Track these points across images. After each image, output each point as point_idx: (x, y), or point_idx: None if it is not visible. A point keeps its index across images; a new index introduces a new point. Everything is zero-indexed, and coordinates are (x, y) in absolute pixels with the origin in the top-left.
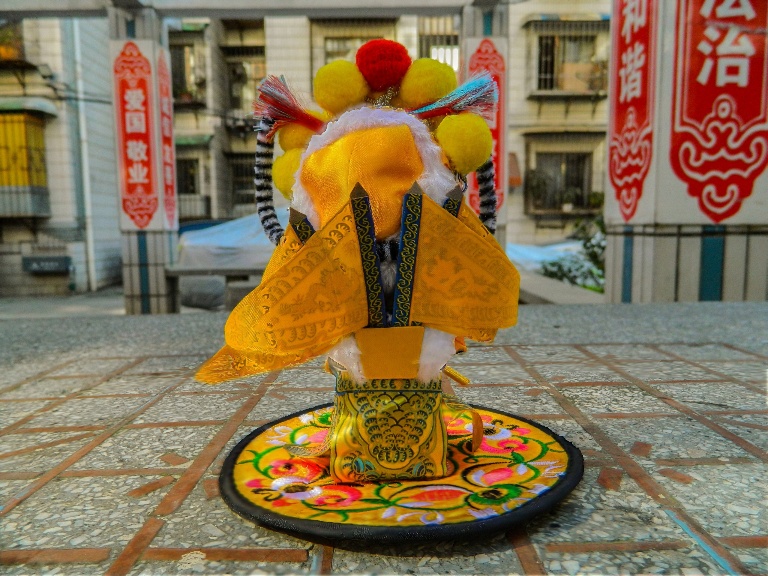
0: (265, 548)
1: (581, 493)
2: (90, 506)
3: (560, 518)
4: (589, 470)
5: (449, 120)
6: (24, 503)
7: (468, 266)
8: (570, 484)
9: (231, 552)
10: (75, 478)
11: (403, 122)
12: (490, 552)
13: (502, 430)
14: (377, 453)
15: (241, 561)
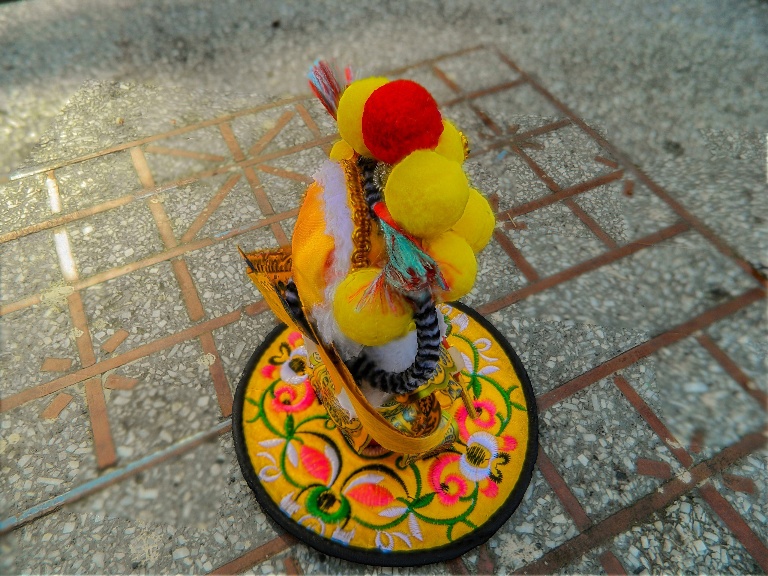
0: (231, 388)
1: (387, 570)
2: (242, 271)
3: (335, 560)
4: (440, 570)
5: (345, 284)
6: (235, 238)
7: (348, 395)
8: (360, 560)
9: (220, 374)
10: (272, 235)
11: (334, 238)
12: (269, 521)
13: (485, 469)
14: (326, 401)
15: (213, 385)
